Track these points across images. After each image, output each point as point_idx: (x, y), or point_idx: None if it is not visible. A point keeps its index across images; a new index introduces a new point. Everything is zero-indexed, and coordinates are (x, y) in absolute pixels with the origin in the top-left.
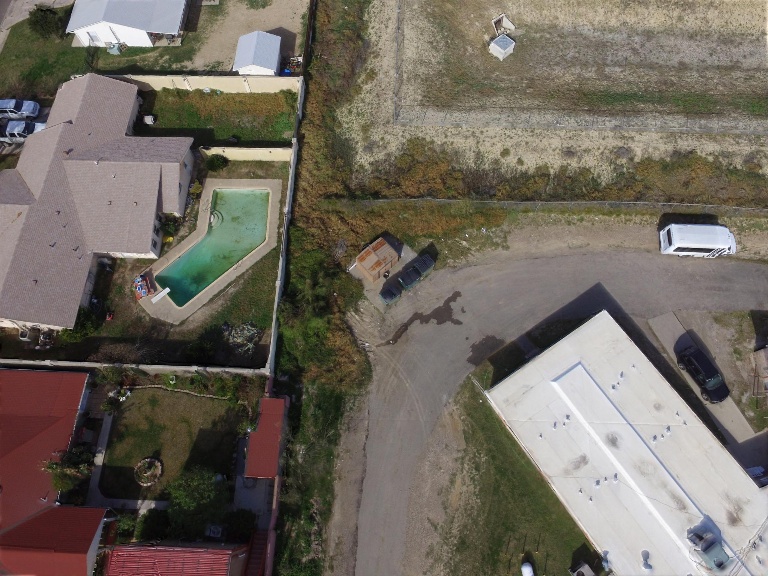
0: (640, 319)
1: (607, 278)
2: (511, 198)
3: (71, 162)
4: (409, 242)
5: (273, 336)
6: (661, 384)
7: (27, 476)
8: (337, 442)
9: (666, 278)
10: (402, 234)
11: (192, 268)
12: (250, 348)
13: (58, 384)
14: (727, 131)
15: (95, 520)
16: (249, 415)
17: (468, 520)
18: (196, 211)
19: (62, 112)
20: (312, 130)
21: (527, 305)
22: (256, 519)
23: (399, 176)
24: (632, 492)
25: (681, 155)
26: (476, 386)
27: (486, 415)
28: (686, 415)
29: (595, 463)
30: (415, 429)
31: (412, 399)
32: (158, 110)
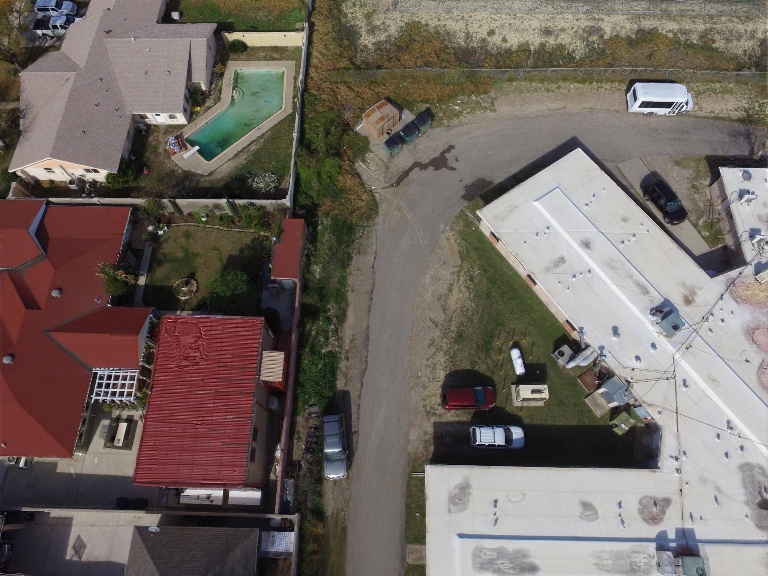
0: (611, 163)
1: (582, 133)
2: (497, 68)
3: (111, 40)
4: (408, 107)
5: (292, 175)
6: (628, 202)
7: (83, 281)
8: (349, 263)
9: (633, 132)
10: (402, 100)
11: (217, 134)
12: (272, 187)
13: (105, 215)
14: (684, 13)
15: (143, 315)
16: (272, 243)
17: (464, 319)
18: (220, 87)
19: (100, 4)
20: (321, 18)
21: (512, 154)
22: (280, 323)
23: (399, 53)
24: (603, 283)
25: (644, 31)
26: (469, 217)
27: (478, 239)
28: (649, 225)
29: (572, 262)
30: (417, 251)
31: (414, 228)
32: (183, 8)
